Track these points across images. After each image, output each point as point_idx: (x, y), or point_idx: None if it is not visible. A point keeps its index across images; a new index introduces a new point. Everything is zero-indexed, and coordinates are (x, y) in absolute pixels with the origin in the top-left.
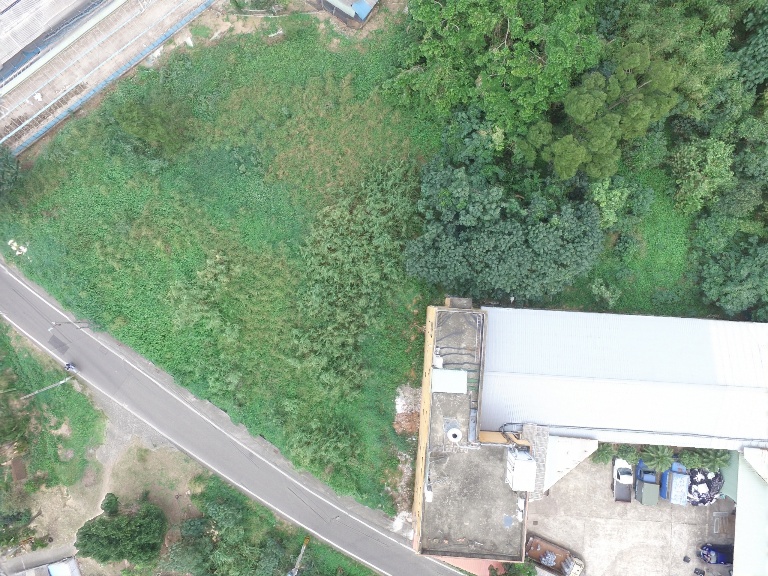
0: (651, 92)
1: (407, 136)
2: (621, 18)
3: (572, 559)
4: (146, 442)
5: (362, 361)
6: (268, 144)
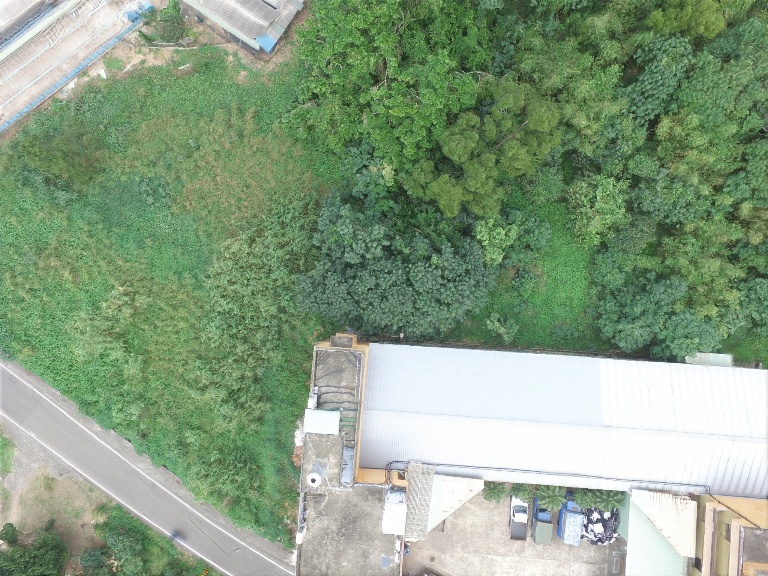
0: (533, 130)
1: (309, 169)
2: (517, 52)
3: None
4: (53, 471)
5: (261, 393)
6: (177, 175)
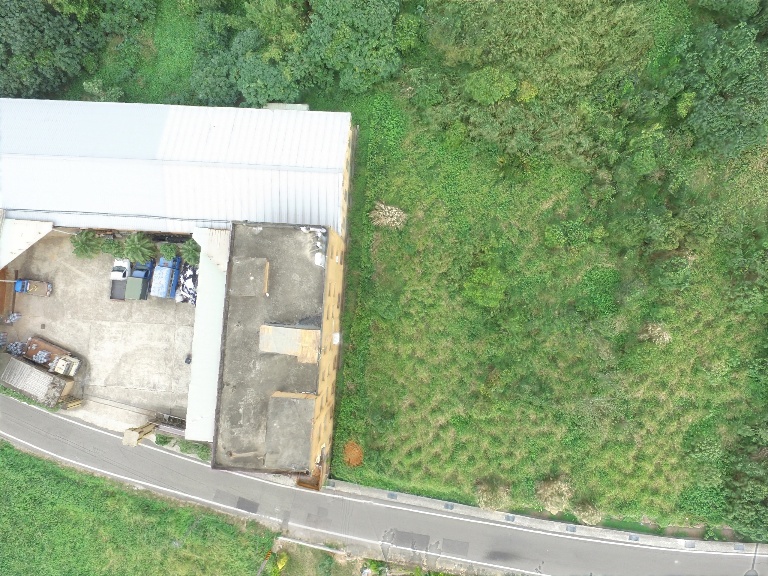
0: None
1: None
2: None
3: None
4: None
5: None
6: None
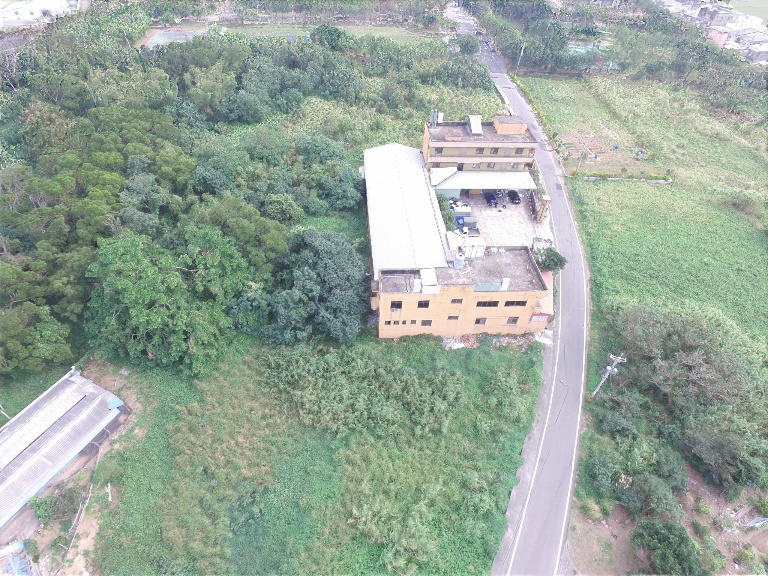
0: None
1: (241, 359)
2: None
3: None
4: None
5: None
6: None
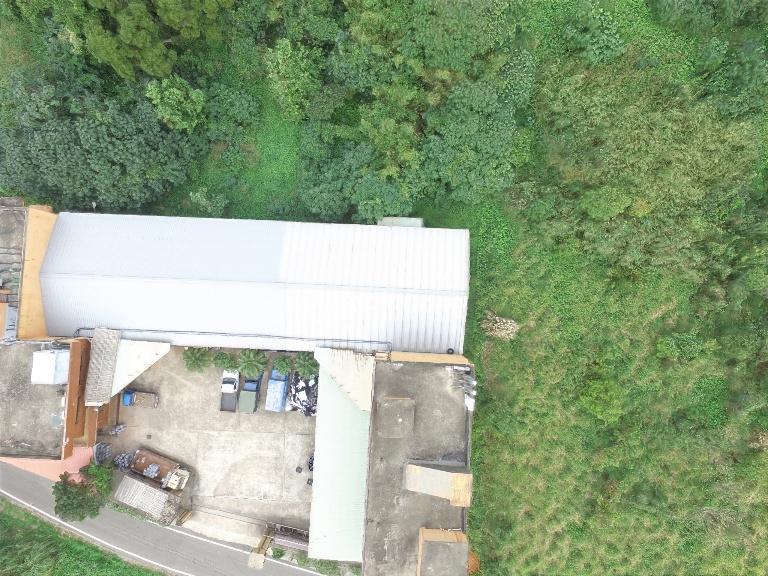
0: None
1: (26, 50)
2: None
3: (173, 470)
4: None
5: None
6: None
